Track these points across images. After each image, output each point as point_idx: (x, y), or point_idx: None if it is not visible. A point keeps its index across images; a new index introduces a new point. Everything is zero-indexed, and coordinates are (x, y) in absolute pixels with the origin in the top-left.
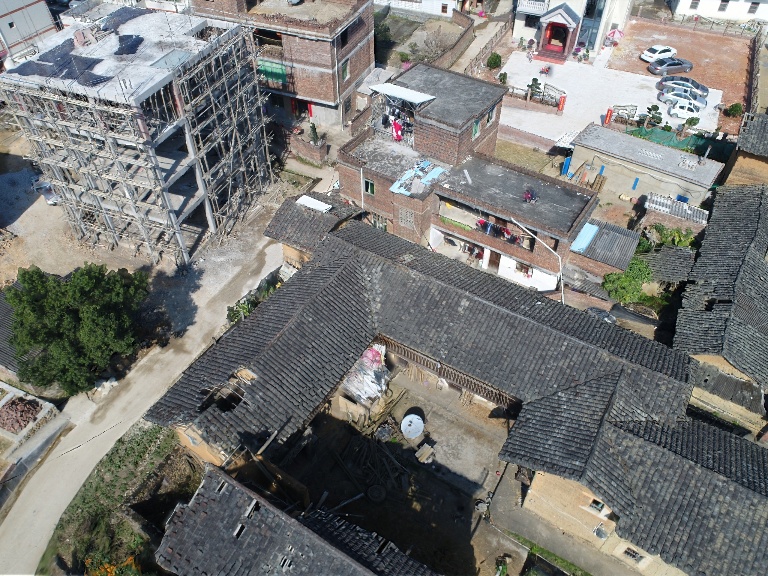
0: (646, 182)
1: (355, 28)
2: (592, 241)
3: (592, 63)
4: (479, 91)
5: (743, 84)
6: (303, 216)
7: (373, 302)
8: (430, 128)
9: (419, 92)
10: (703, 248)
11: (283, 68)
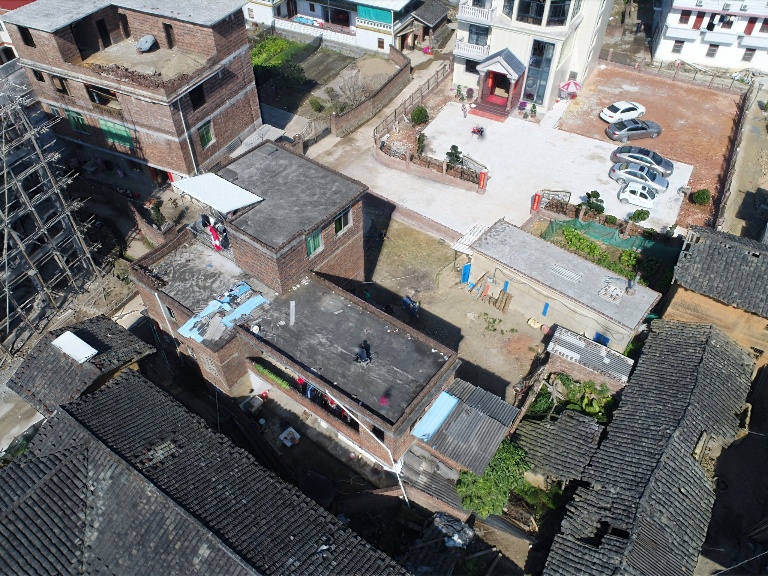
0: (558, 310)
1: (218, 83)
2: (444, 422)
3: (539, 121)
4: (328, 189)
5: (721, 157)
6: (59, 362)
7: (88, 528)
8: (245, 245)
9: (244, 190)
10: (613, 425)
11: (127, 130)
